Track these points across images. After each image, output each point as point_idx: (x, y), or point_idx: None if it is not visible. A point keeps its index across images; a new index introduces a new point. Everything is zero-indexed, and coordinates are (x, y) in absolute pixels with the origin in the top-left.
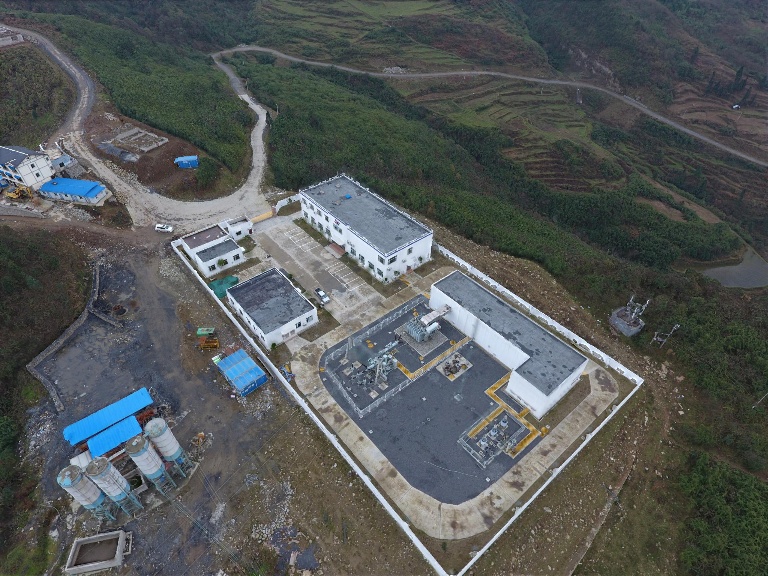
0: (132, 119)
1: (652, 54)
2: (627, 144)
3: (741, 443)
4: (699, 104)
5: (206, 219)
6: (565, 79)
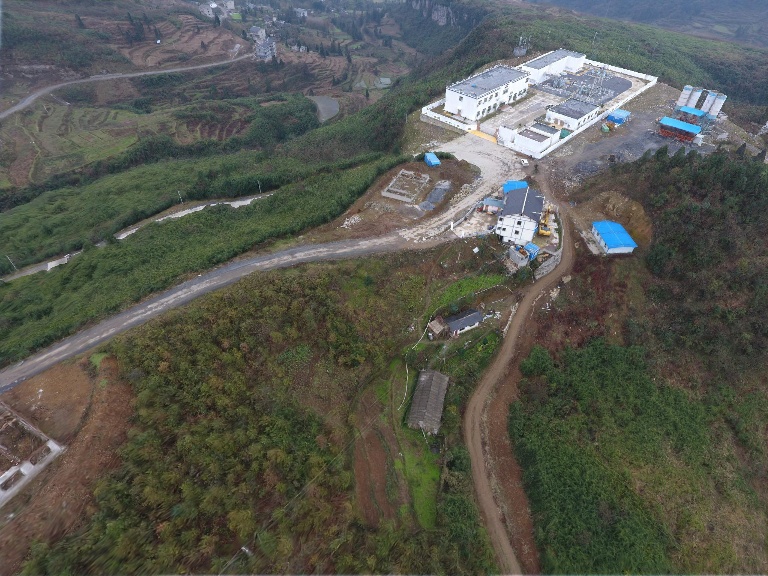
0: (354, 205)
1: (65, 33)
2: (155, 104)
3: None
4: (139, 53)
5: (495, 155)
6: (23, 95)
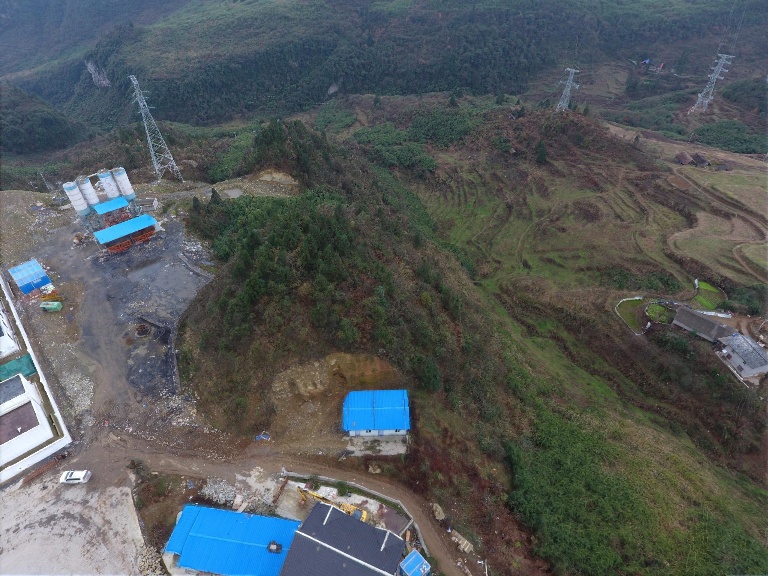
0: None
1: None
2: None
3: None
4: None
5: None
6: None
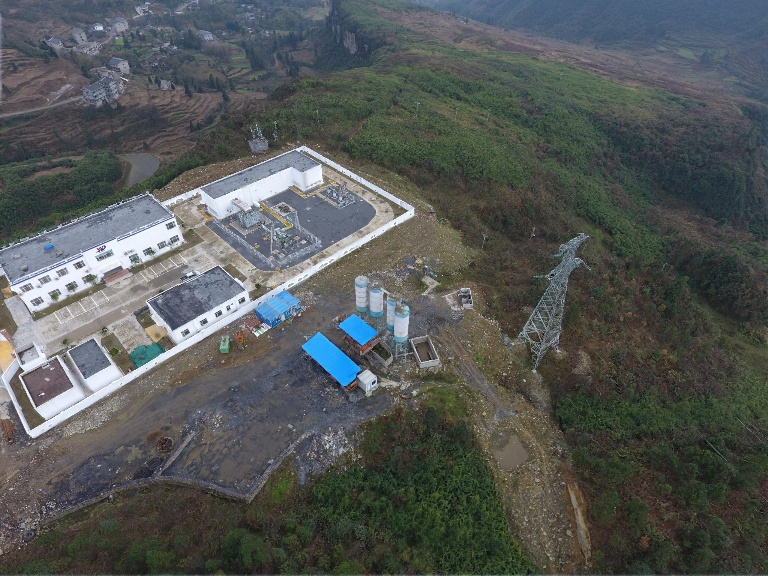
0: None
1: None
2: None
3: (337, 135)
4: None
5: None
6: None
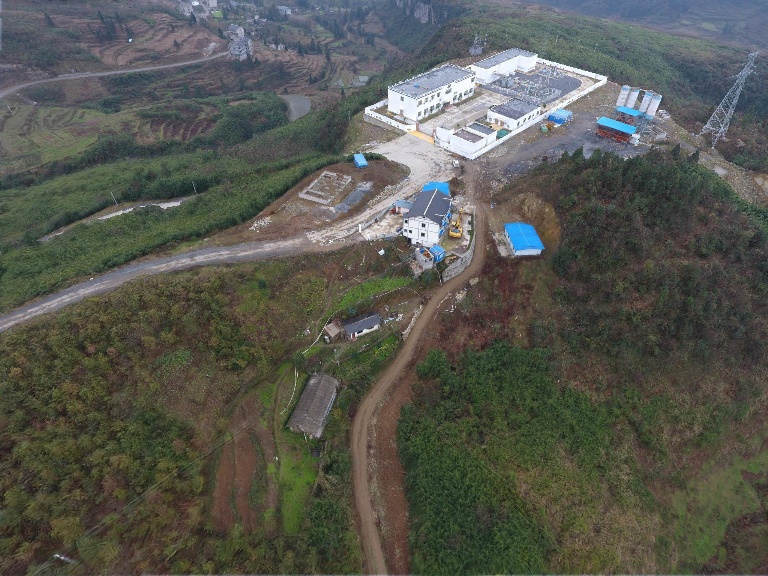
0: (268, 207)
1: (32, 32)
2: (125, 103)
3: None
4: (110, 51)
5: (430, 156)
6: None
